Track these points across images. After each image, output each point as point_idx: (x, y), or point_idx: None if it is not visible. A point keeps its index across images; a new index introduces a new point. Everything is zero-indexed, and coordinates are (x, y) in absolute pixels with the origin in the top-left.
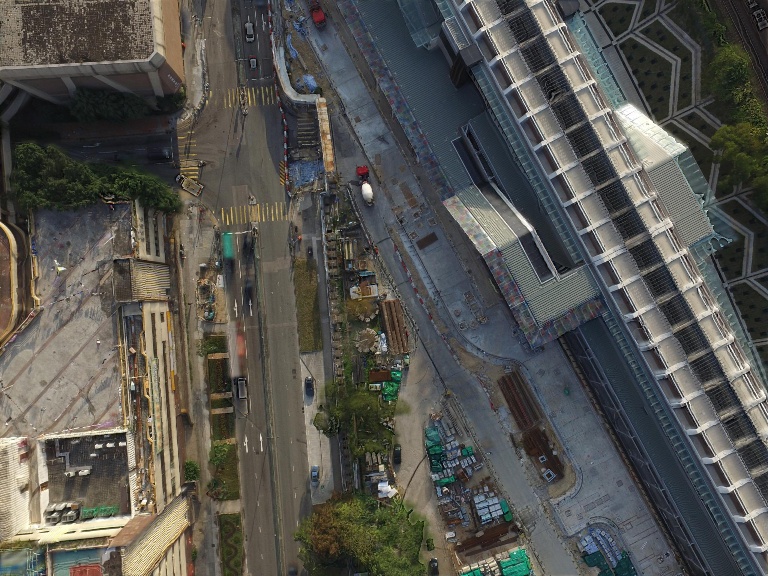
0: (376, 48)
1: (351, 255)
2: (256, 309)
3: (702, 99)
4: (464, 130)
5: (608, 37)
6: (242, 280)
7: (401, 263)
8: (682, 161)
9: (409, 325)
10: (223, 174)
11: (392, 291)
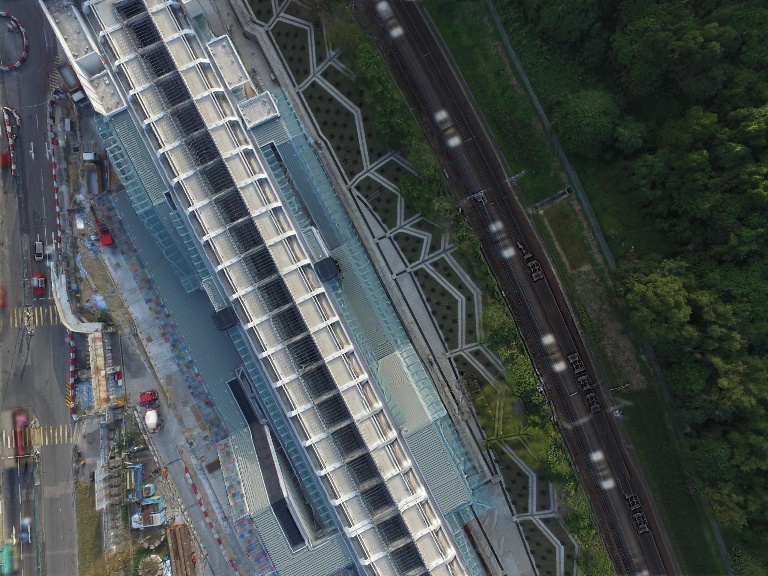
0: (153, 285)
1: (133, 484)
2: (35, 536)
3: (486, 338)
4: (238, 373)
5: (403, 263)
6: (21, 506)
7: (191, 485)
8: (473, 392)
9: (197, 550)
10: (6, 396)
11: (181, 514)
